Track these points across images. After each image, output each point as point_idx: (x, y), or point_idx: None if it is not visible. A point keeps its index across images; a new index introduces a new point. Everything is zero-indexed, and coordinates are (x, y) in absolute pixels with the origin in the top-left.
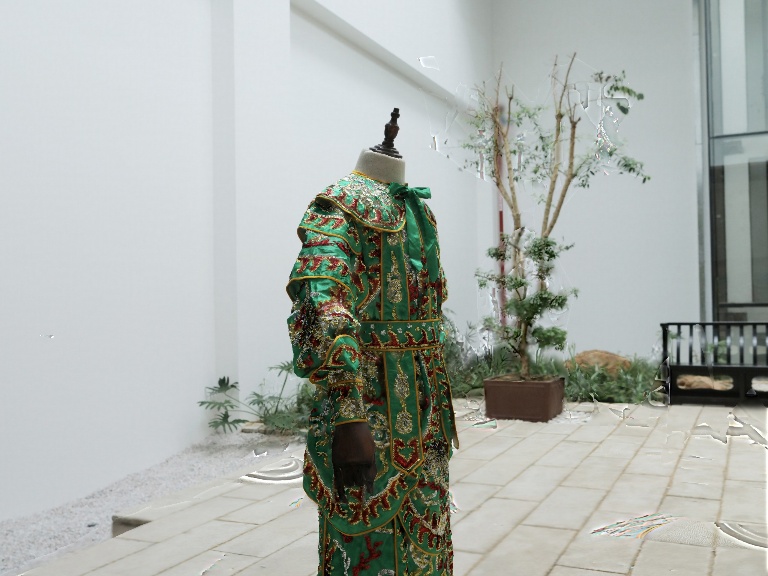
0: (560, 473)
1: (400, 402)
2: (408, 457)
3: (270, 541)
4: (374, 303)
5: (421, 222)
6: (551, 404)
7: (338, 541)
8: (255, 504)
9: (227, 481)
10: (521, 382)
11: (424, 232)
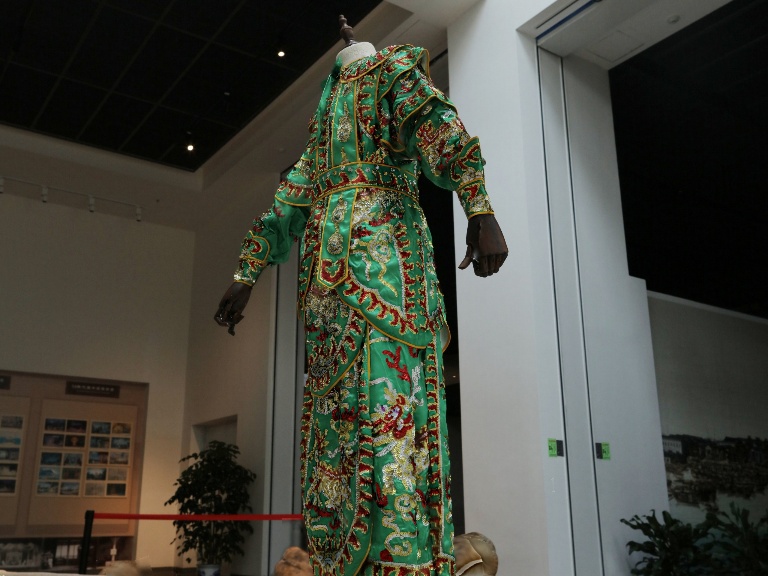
0: None
1: None
2: None
3: None
4: None
5: None
6: None
7: None
8: None
9: None
10: None
11: None
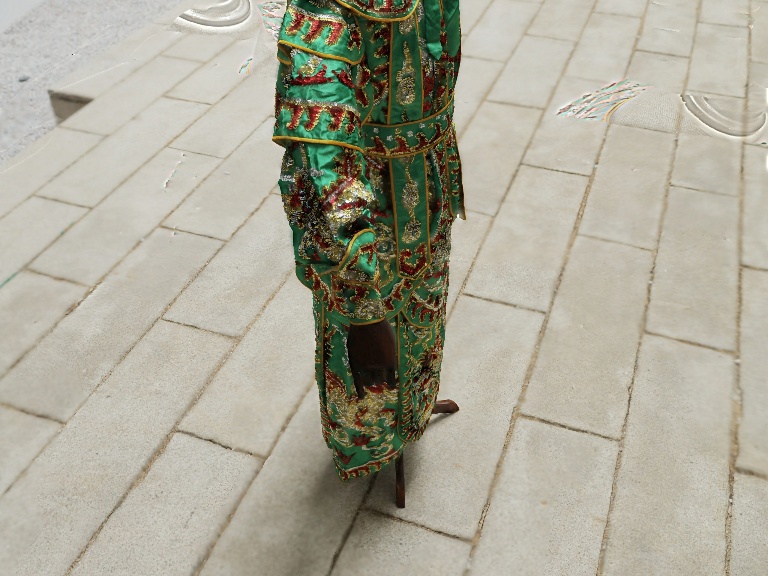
0: (526, 13)
1: (408, 213)
2: (415, 263)
3: (228, 132)
4: (379, 107)
5: None
6: None
7: (337, 326)
8: (201, 69)
9: (163, 29)
10: None
11: None
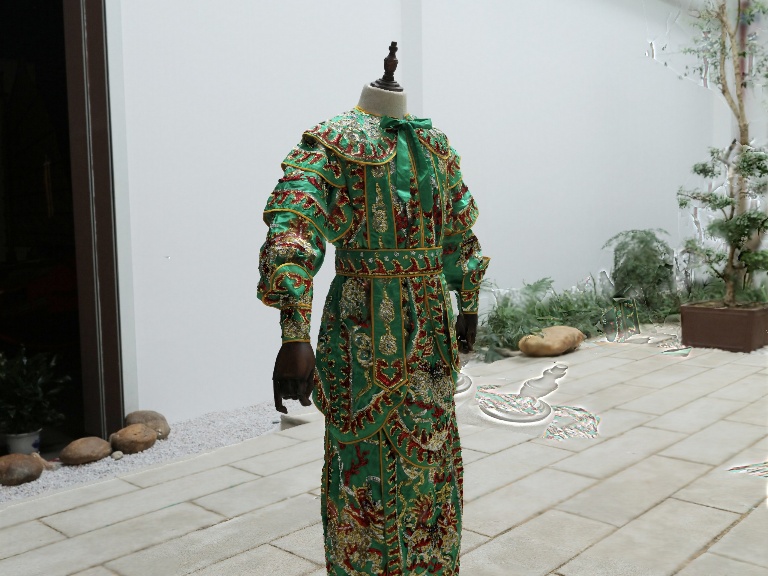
0: (730, 407)
1: (384, 325)
2: (392, 376)
3: None
4: (361, 232)
5: (416, 153)
6: (755, 334)
7: (337, 447)
8: None
9: None
10: (722, 309)
11: (418, 163)
